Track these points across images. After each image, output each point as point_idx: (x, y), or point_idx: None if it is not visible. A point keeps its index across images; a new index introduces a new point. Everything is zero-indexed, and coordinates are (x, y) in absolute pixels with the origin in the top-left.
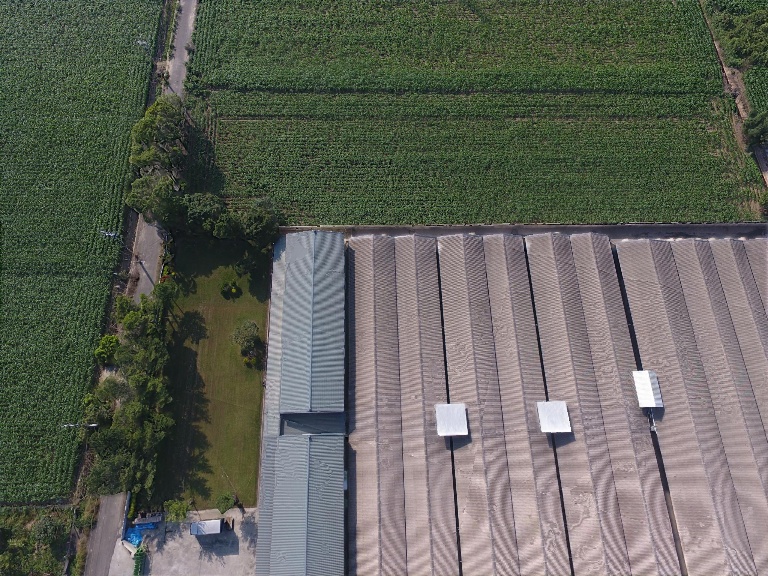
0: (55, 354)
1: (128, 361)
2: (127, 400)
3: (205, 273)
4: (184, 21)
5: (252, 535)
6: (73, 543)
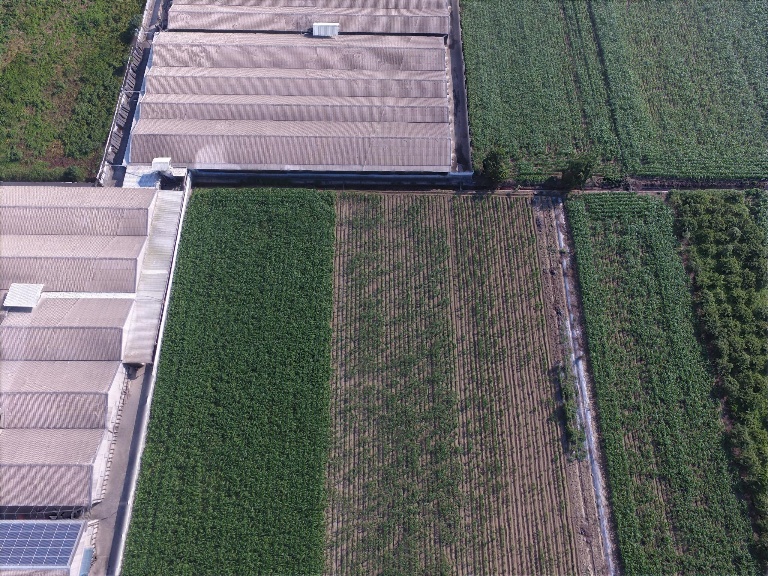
0: None
1: None
2: None
3: None
4: None
5: None
6: None
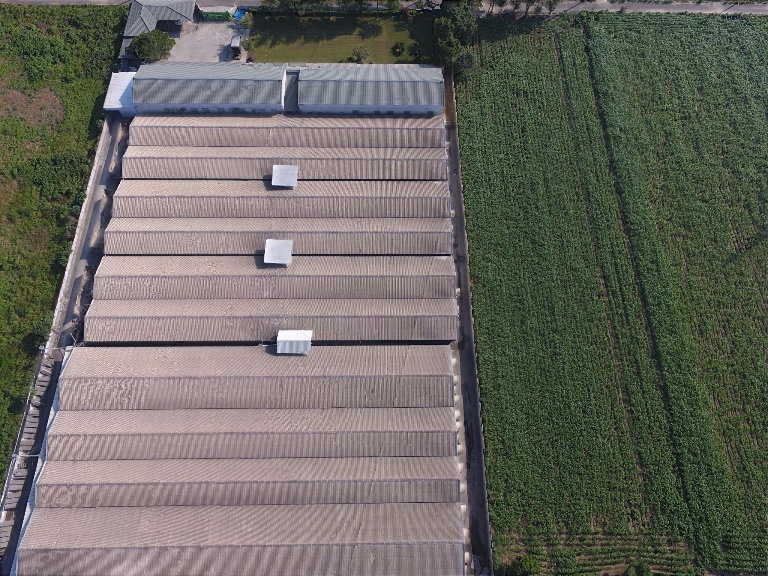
0: None
1: None
2: None
3: (413, 35)
4: (654, 6)
5: None
6: None
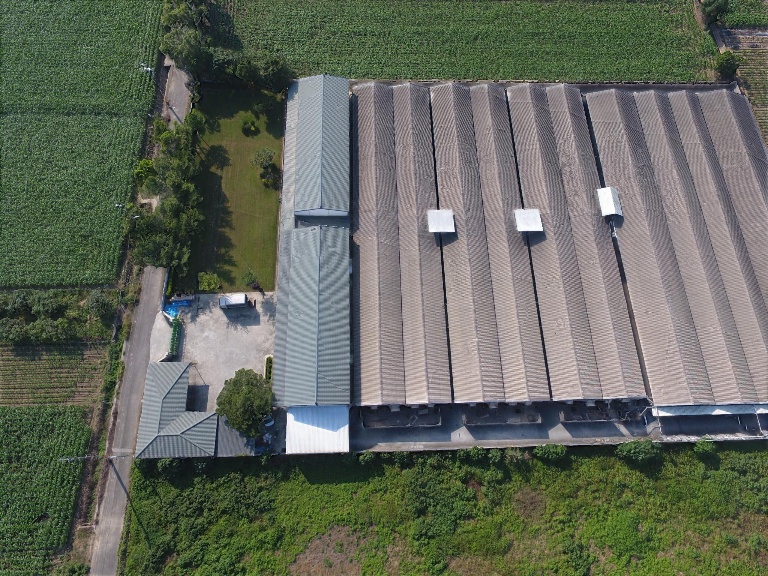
0: (100, 174)
1: (165, 167)
2: (165, 197)
3: (227, 116)
4: None
5: (271, 311)
6: (119, 316)
